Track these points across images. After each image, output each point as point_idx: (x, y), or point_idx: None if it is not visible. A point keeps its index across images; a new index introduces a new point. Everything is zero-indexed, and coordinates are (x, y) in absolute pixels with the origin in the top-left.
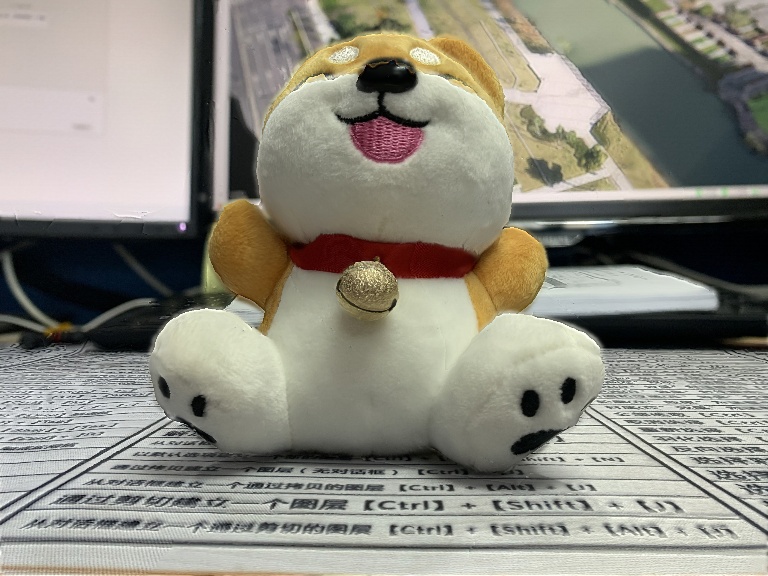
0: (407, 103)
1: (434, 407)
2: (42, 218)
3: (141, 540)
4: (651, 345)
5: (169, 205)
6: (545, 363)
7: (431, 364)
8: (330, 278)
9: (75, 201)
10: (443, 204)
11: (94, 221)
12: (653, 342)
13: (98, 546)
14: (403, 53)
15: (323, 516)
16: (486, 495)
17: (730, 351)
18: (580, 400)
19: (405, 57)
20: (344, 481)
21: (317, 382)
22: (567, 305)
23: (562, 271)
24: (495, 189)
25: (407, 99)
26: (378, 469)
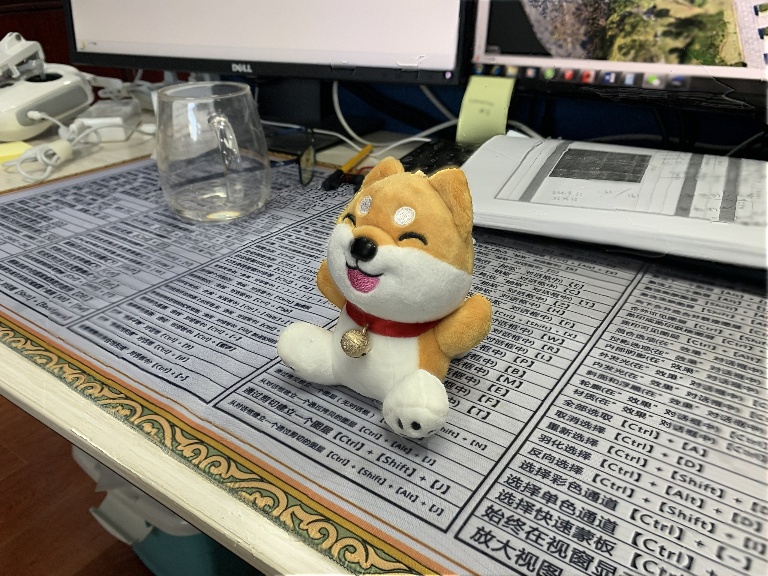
0: (368, 268)
1: None
2: (348, 66)
3: (254, 425)
4: None
5: (440, 52)
6: (405, 413)
7: (385, 381)
8: (352, 323)
9: (370, 51)
10: (393, 312)
11: (383, 69)
12: None
13: (242, 423)
14: (387, 218)
15: (316, 436)
16: (385, 448)
17: None
18: (421, 431)
19: (387, 222)
20: (346, 415)
21: (342, 370)
22: (707, 250)
23: None
24: (427, 304)
25: (368, 266)
26: (369, 410)
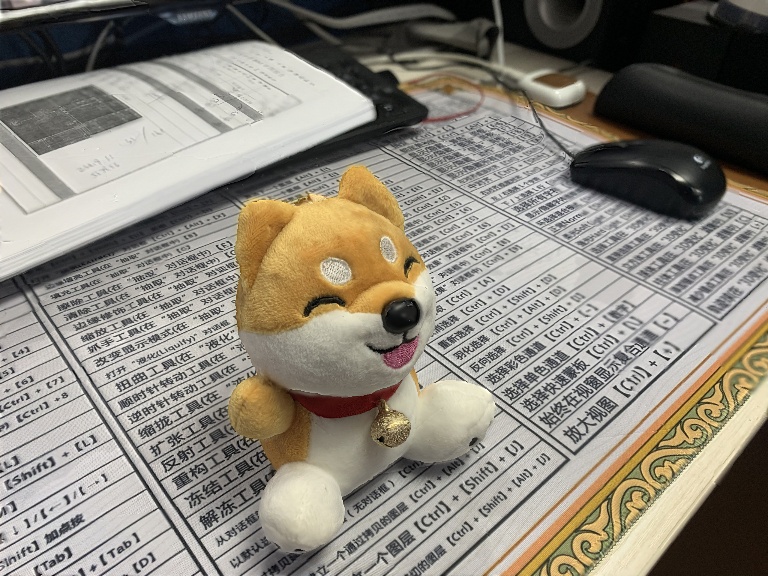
0: (418, 330)
1: (412, 449)
2: None
3: None
4: (330, 152)
5: None
6: (482, 426)
7: None
8: (351, 420)
9: None
10: None
11: None
12: (332, 150)
13: None
14: (385, 264)
15: (415, 552)
16: (452, 482)
17: (382, 148)
18: None
19: (388, 268)
20: (382, 511)
21: (359, 478)
22: (279, 150)
23: (228, 68)
24: None
25: (418, 328)
26: (381, 485)
